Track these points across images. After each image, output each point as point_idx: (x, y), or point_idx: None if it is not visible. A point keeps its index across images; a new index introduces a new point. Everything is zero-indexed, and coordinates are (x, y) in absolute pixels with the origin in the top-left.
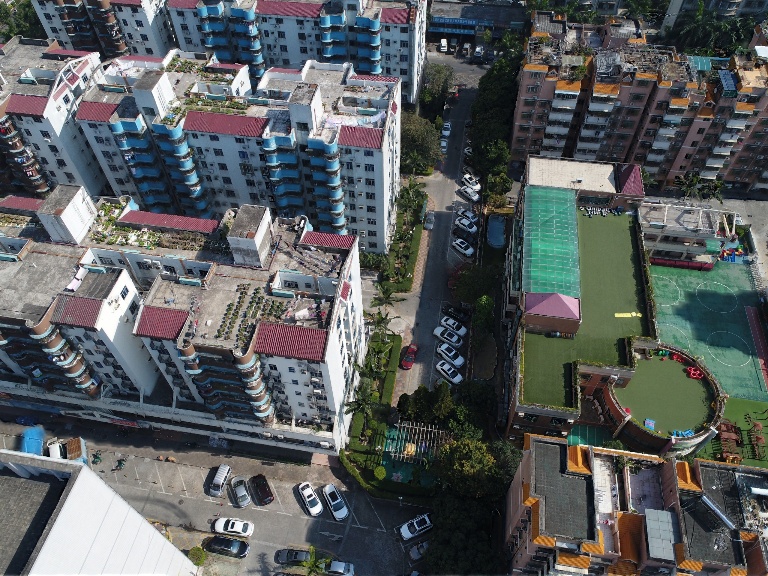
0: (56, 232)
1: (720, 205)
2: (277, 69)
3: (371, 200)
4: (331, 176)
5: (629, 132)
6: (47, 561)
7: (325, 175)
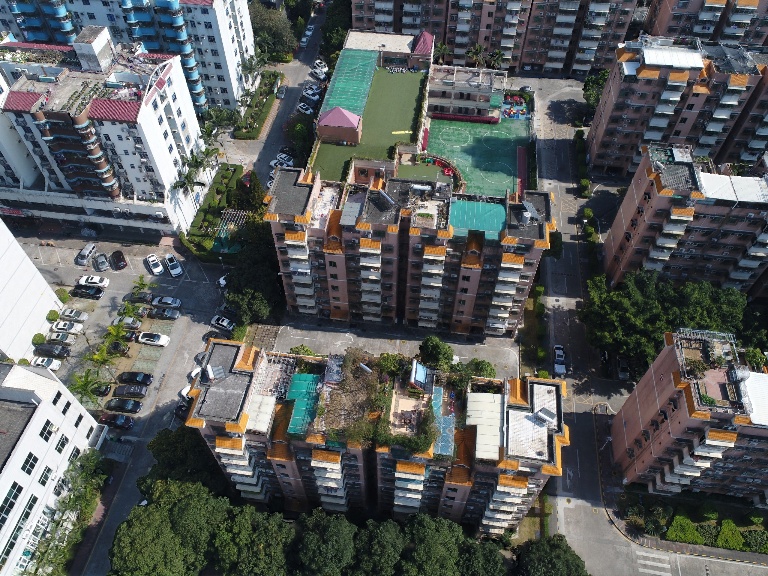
0: None
1: (519, 82)
2: None
3: (216, 57)
4: (178, 31)
5: (441, 20)
6: None
7: (173, 31)
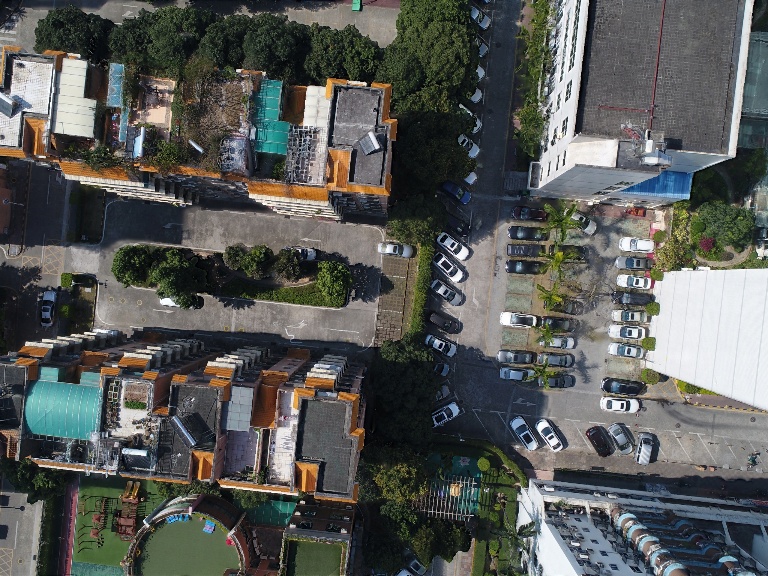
0: None
1: None
2: None
3: None
4: None
5: None
6: None
7: None
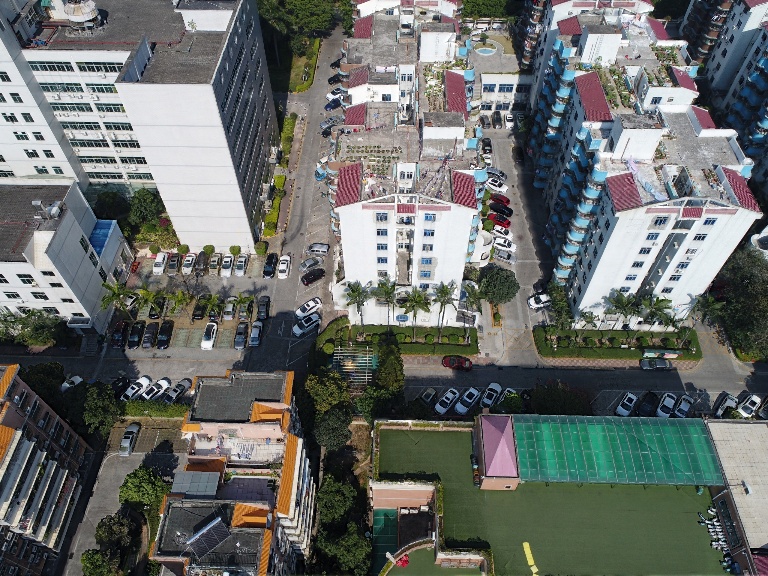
0: None
1: None
2: (705, 113)
3: (594, 257)
4: (582, 198)
5: None
6: (163, 93)
7: None
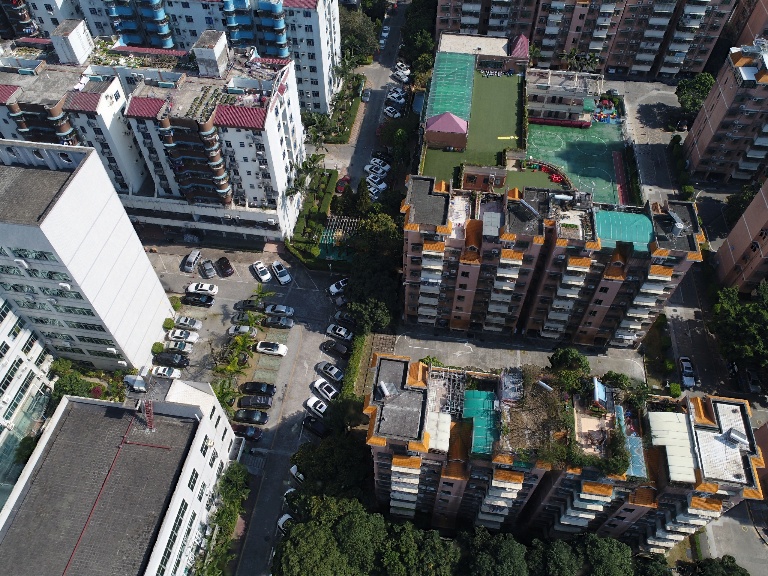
0: (64, 53)
1: (604, 85)
2: None
3: (312, 60)
4: (278, 34)
5: (528, 22)
6: (72, 197)
7: (274, 34)
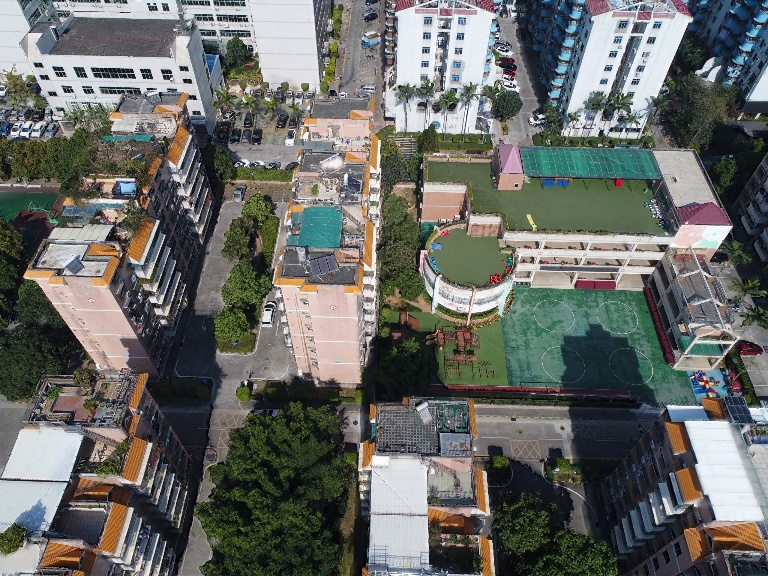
0: None
1: None
2: None
3: None
4: (569, 21)
5: None
6: None
7: None
